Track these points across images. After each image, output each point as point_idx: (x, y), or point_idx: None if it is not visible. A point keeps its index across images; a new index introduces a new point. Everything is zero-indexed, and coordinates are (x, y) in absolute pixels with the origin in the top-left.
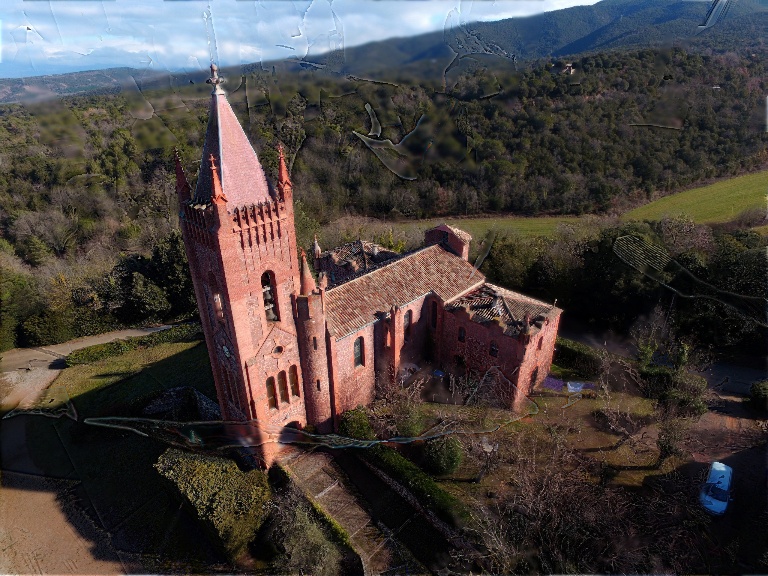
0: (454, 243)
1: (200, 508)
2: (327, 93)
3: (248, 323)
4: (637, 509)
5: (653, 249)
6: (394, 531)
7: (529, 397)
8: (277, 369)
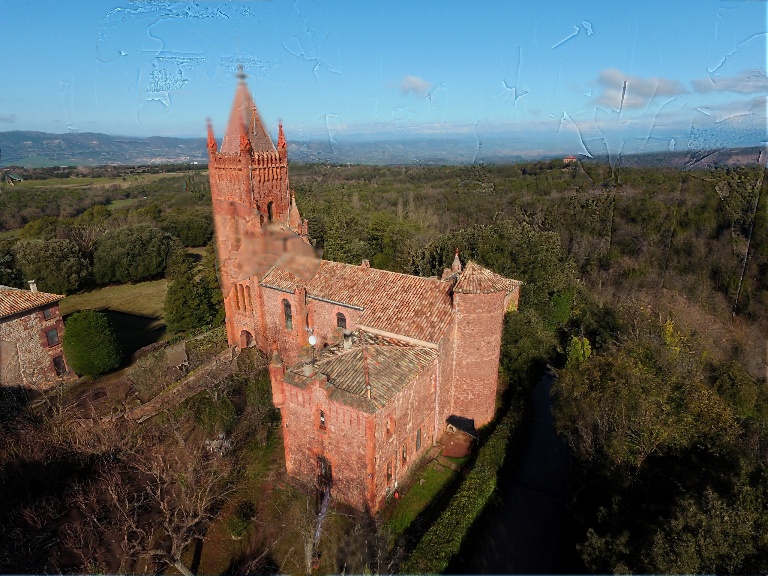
0: None
1: None
2: (713, 116)
3: None
4: (1, 457)
5: None
6: None
7: (315, 491)
8: None
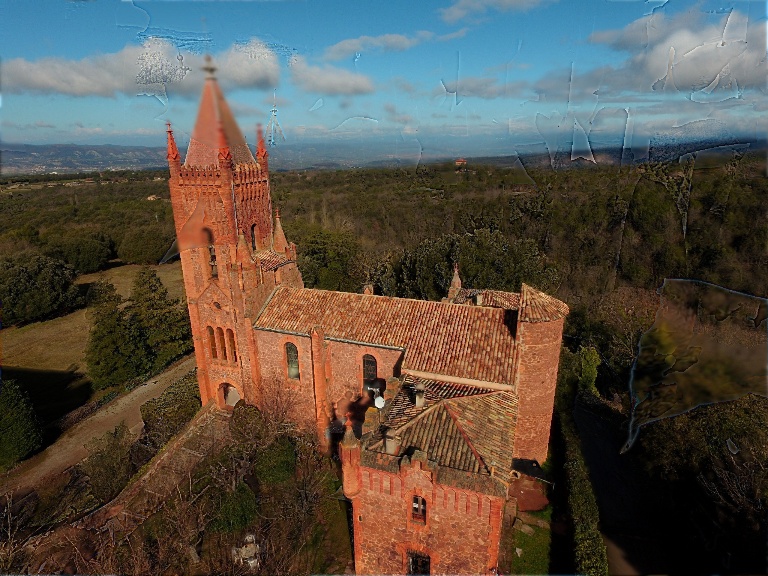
0: None
1: (162, 394)
2: (670, 122)
3: (192, 267)
4: None
5: None
6: None
7: None
8: (216, 323)
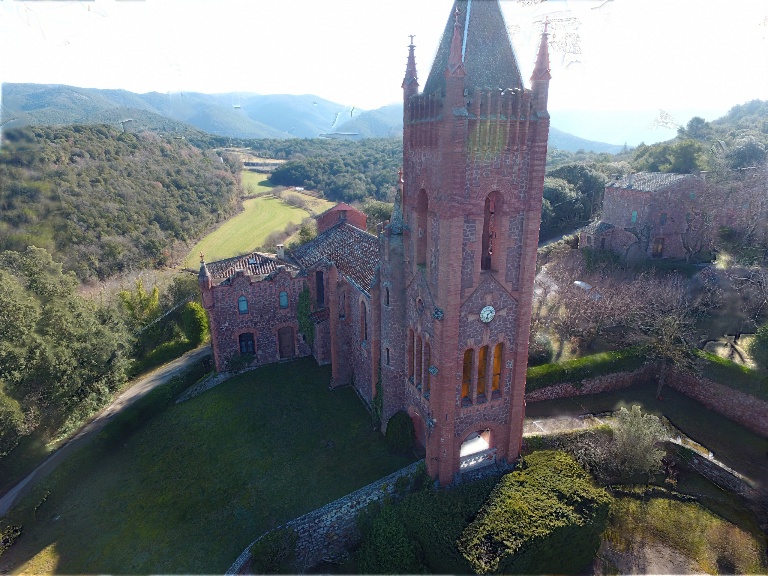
0: (355, 219)
1: None
2: None
3: None
4: None
5: (666, 110)
6: (588, 412)
7: None
8: None
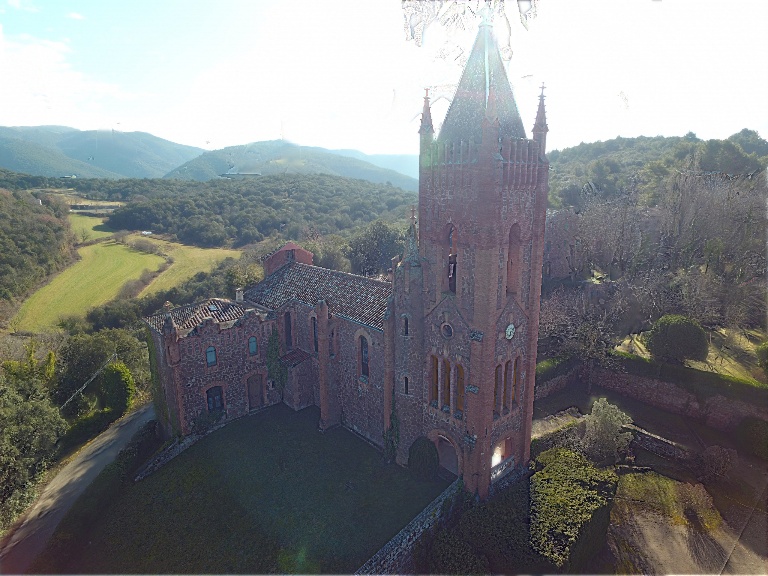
0: (303, 258)
1: None
2: None
3: None
4: None
5: None
6: (549, 414)
7: None
8: None
